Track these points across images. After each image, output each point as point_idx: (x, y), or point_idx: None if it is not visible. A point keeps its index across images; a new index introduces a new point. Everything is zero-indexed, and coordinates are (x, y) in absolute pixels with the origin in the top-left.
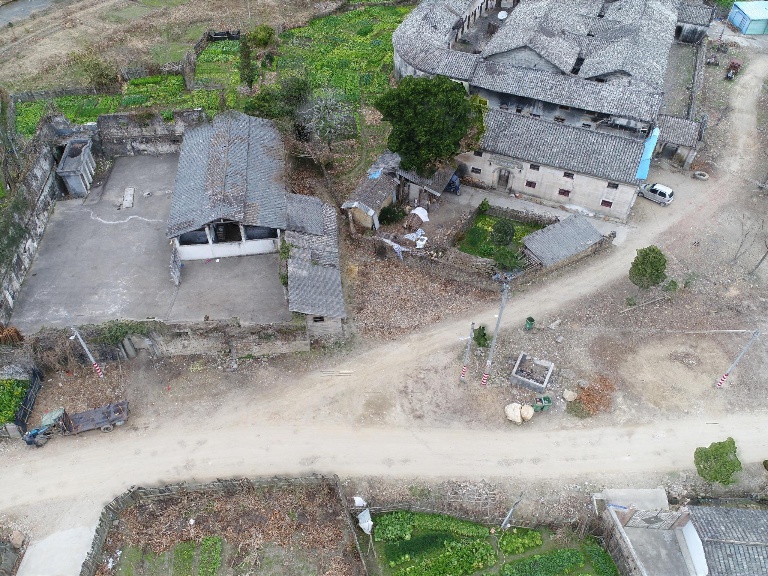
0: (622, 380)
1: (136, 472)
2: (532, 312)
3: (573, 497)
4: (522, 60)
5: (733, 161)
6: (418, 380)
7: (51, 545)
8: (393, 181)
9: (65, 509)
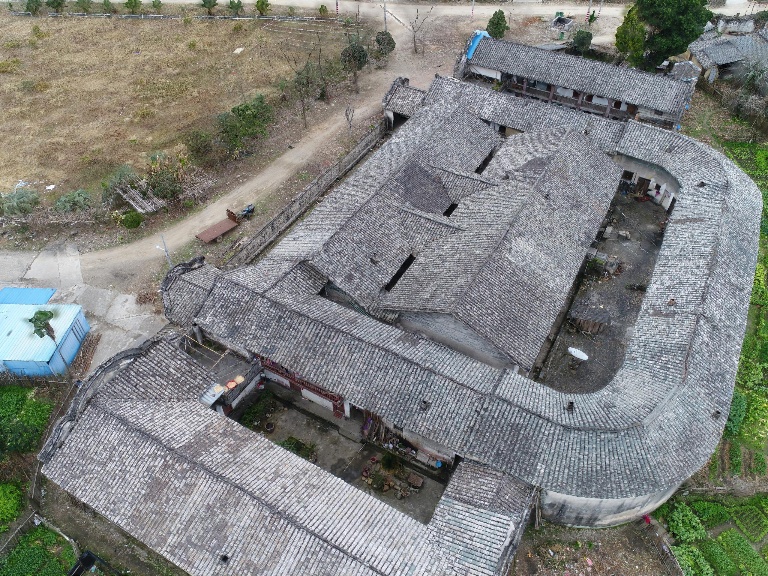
0: (517, 24)
1: (727, 11)
2: None
3: (549, 2)
4: None
5: (357, 114)
6: (618, 25)
7: (740, 1)
8: None
9: (745, 6)
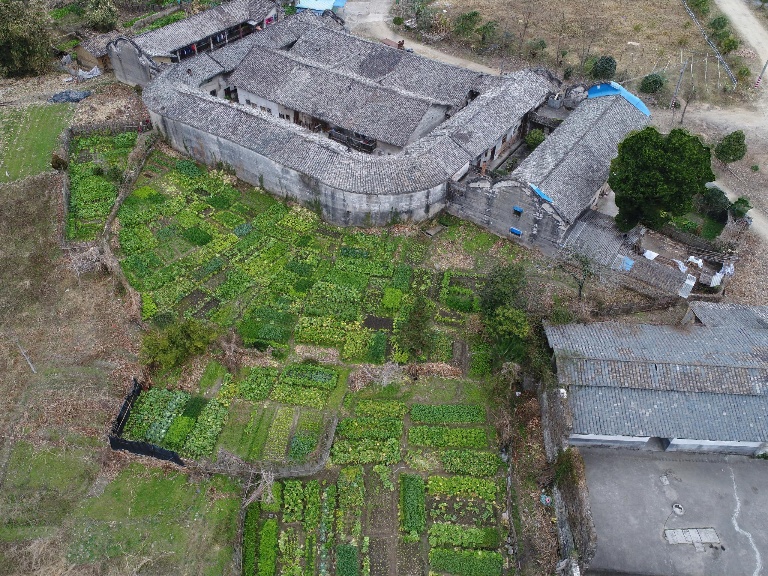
0: None
1: None
2: (762, 220)
3: None
4: (425, 120)
5: None
6: None
7: None
8: (632, 253)
9: None
